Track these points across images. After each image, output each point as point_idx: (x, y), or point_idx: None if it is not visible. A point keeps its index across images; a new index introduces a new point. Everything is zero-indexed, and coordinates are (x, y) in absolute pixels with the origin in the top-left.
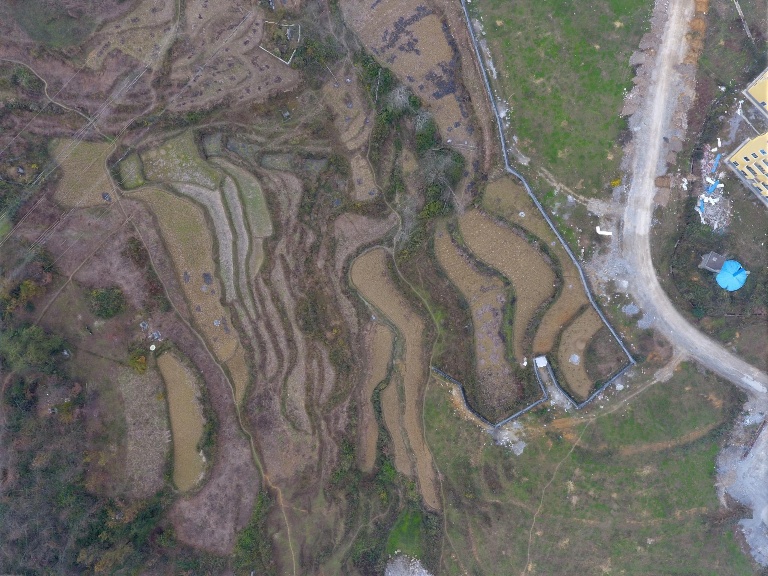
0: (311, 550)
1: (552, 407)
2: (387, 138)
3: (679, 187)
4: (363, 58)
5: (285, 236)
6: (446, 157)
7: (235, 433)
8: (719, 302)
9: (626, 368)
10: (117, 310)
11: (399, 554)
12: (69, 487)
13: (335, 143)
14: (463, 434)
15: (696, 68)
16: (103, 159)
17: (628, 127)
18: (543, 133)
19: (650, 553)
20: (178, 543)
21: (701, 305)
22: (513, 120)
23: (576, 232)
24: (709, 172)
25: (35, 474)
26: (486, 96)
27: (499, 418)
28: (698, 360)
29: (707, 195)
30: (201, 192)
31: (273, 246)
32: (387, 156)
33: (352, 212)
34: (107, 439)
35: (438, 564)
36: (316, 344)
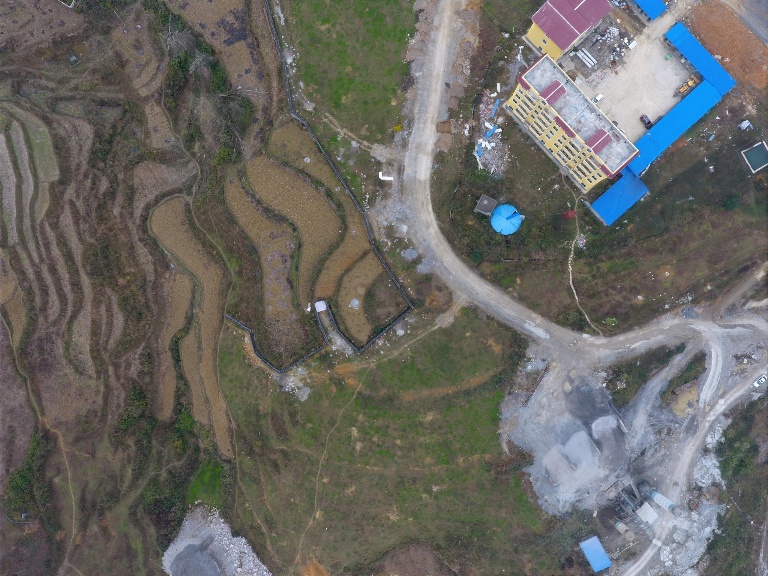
0: (94, 495)
1: (334, 352)
2: (185, 86)
3: (461, 133)
4: (154, 5)
5: (74, 181)
6: None
7: (10, 375)
8: (493, 246)
9: (405, 313)
10: None
11: (200, 504)
12: None
13: (127, 89)
14: (254, 381)
15: (479, 14)
16: None
17: (410, 72)
18: (328, 79)
19: (436, 501)
20: None
21: (476, 249)
22: (299, 66)
23: (361, 178)
24: (488, 117)
25: None
26: (273, 42)
27: (285, 364)
28: (478, 306)
29: (485, 140)
30: None
31: (61, 191)
32: (185, 104)
33: (151, 160)
34: None
35: (232, 513)
36: (106, 290)
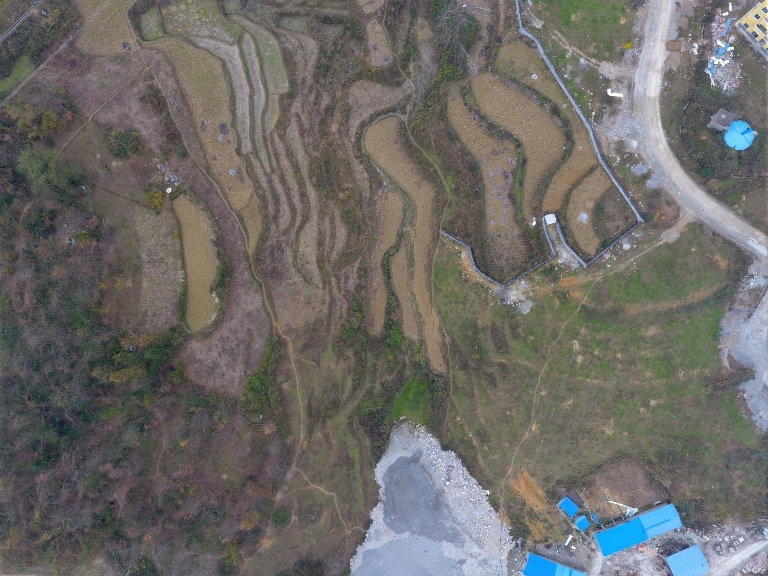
0: (319, 402)
1: (560, 266)
2: (403, 7)
3: (690, 52)
4: None
5: (301, 95)
6: None
7: (247, 279)
8: (727, 161)
9: (634, 227)
10: (135, 152)
11: (404, 420)
12: (85, 311)
13: (352, 6)
14: (471, 296)
15: None
16: (124, 9)
17: None
18: None
19: (653, 415)
20: (189, 382)
21: (709, 164)
22: None
23: (587, 95)
24: (720, 35)
25: (51, 300)
26: None
27: (507, 278)
28: (705, 222)
29: (717, 57)
30: (219, 46)
31: (289, 104)
32: (402, 24)
33: (367, 79)
34: (122, 273)
35: (443, 427)
36: (328, 203)
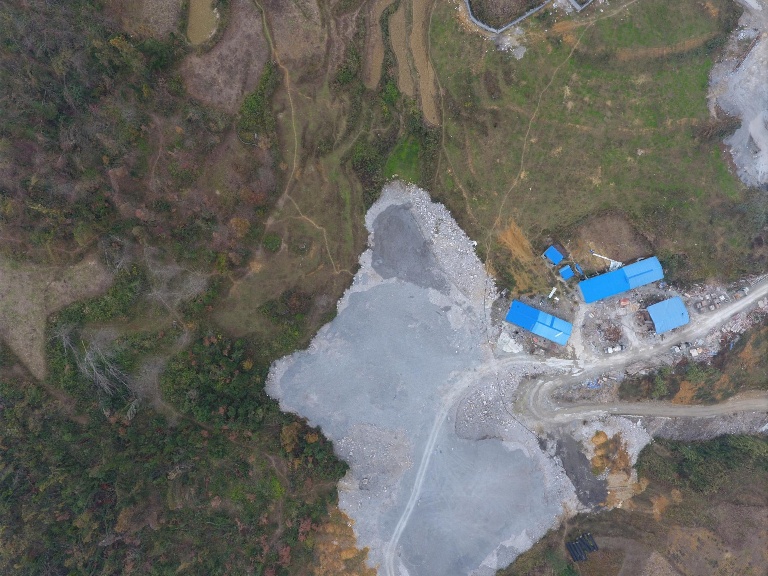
0: (313, 137)
1: (554, 10)
2: None
3: None
4: None
5: None
6: None
7: (248, 4)
8: None
9: None
10: None
11: (396, 178)
12: None
13: None
14: (466, 47)
15: None
16: None
17: None
18: None
19: (640, 165)
20: (187, 94)
21: None
22: None
23: None
24: None
25: None
26: None
27: (502, 25)
28: None
29: None
30: None
31: None
32: None
33: None
34: None
35: (434, 179)
36: None
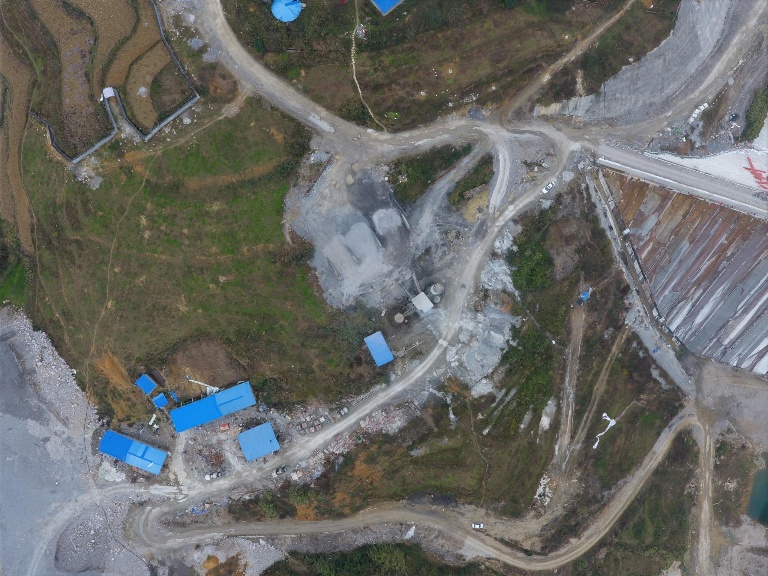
0: None
1: (123, 140)
2: None
3: None
4: None
5: None
6: None
7: None
8: (273, 32)
9: (190, 100)
10: None
11: (8, 304)
12: None
13: None
14: (53, 175)
15: None
16: None
17: None
18: None
19: (223, 291)
20: None
21: (257, 36)
22: None
23: None
24: None
25: None
26: None
27: (79, 154)
28: (263, 96)
29: None
30: None
31: None
32: None
33: None
34: None
35: (33, 307)
36: None
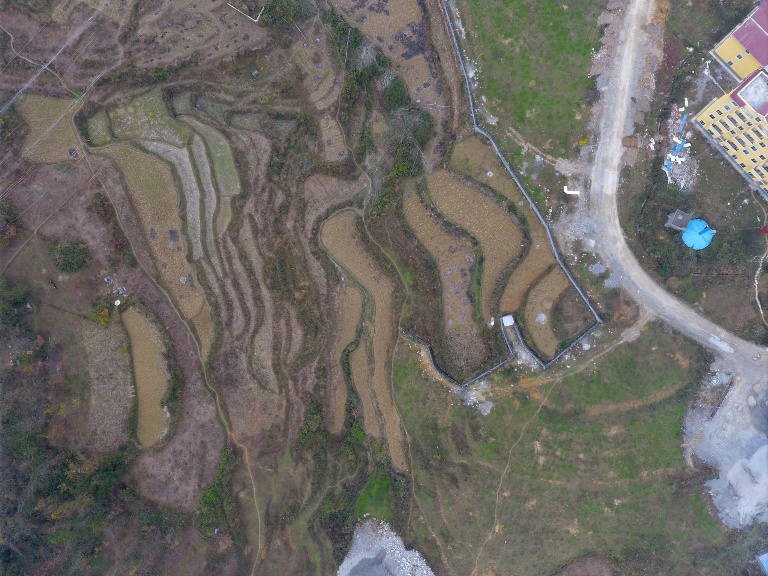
0: (277, 509)
1: (519, 367)
2: (357, 99)
3: (647, 147)
4: (333, 18)
5: (253, 195)
6: (415, 117)
7: (200, 390)
8: (685, 261)
9: (593, 327)
10: (82, 265)
11: (368, 517)
12: (29, 438)
13: (304, 103)
14: (431, 395)
15: (664, 29)
16: (70, 115)
17: (596, 87)
18: (511, 93)
19: (617, 514)
20: (141, 499)
21: (667, 264)
22: (482, 80)
23: (544, 192)
24: (676, 132)
25: None
26: (455, 56)
27: (466, 378)
28: (665, 320)
29: (674, 154)
30: (169, 150)
31: (241, 205)
32: (357, 117)
33: (322, 173)
34: (70, 393)
35: (406, 526)
36: (284, 304)
